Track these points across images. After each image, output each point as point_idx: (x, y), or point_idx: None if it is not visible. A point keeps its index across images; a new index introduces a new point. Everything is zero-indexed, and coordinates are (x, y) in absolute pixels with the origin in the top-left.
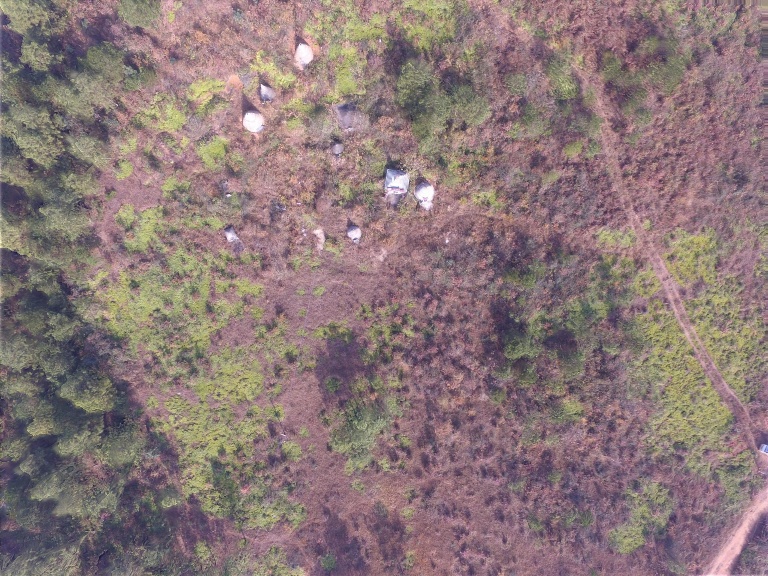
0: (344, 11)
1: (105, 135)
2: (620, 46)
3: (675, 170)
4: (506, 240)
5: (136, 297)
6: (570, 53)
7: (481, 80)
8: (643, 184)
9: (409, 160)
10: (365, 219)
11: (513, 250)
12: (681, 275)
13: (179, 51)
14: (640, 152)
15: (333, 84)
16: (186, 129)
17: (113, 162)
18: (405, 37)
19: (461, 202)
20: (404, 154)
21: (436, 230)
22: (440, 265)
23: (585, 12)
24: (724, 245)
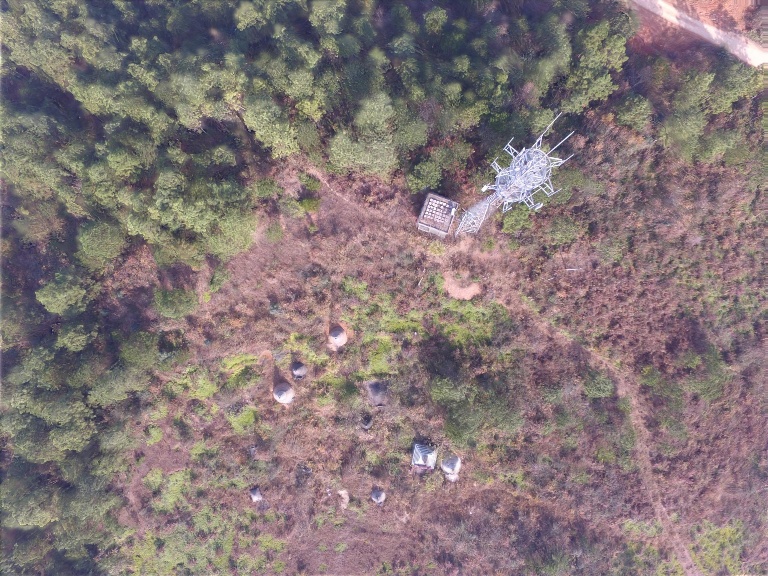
0: (381, 306)
1: (137, 405)
2: (659, 348)
3: (706, 468)
4: (531, 522)
5: (161, 553)
6: (607, 356)
7: (516, 379)
8: (673, 483)
9: (438, 438)
10: (390, 487)
11: (537, 532)
12: (705, 564)
13: (213, 332)
14: (672, 451)
15: (366, 367)
16: (217, 398)
17: (143, 427)
18: (441, 331)
19: (488, 481)
20: (433, 433)
21: (461, 501)
22: (463, 538)
23: (626, 321)
24: (751, 535)
